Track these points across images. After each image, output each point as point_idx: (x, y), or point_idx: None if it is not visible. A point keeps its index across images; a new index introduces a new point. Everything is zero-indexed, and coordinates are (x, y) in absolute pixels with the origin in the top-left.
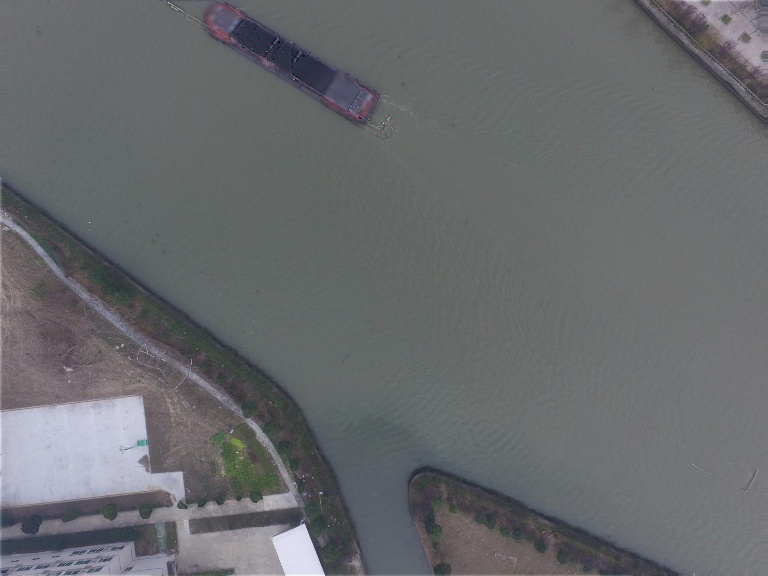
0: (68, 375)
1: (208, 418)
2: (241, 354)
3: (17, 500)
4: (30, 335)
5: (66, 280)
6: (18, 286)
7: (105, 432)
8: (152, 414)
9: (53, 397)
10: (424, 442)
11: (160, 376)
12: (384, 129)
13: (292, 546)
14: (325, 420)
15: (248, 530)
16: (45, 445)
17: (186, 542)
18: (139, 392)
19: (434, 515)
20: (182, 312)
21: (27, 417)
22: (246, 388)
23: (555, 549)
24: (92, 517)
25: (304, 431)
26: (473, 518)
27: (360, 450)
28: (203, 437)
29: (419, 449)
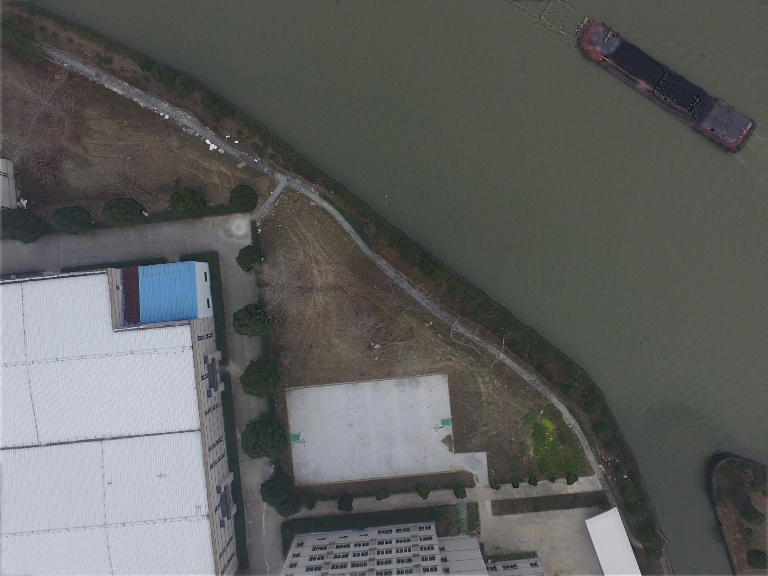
0: (375, 352)
1: (519, 398)
2: (540, 335)
3: (317, 478)
4: (343, 310)
5: (372, 256)
6: (330, 261)
7: (408, 410)
8: (457, 393)
9: (358, 374)
10: (725, 427)
11: (470, 355)
12: (692, 111)
13: (606, 529)
14: (626, 403)
15: (552, 513)
16: (347, 422)
17: (488, 523)
18: (444, 371)
19: (750, 501)
20: (484, 291)
21: (329, 394)
22: (552, 369)
23: None
24: (393, 496)
25: (610, 413)
26: None
27: (660, 434)
28: (514, 417)
29: (719, 434)
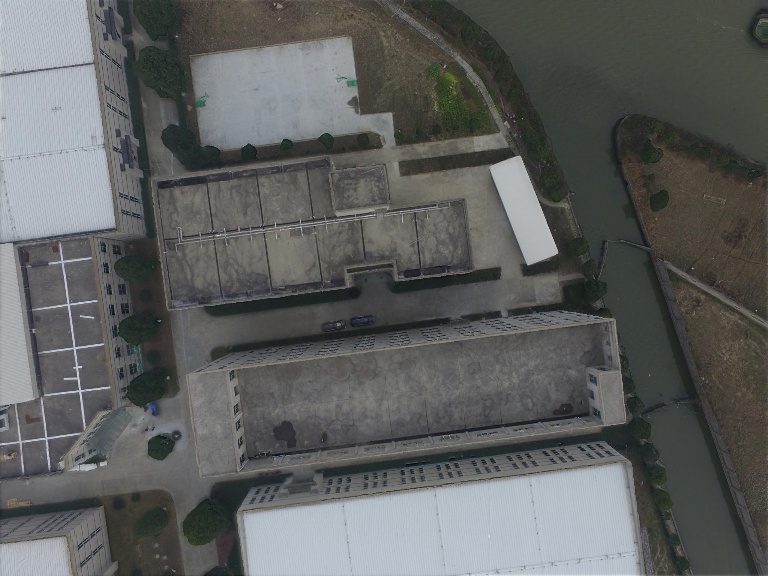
0: (278, 13)
1: (422, 51)
2: None
3: (224, 144)
4: None
5: None
6: None
7: (313, 73)
8: (361, 54)
9: (261, 37)
10: (629, 90)
11: (372, 11)
12: None
13: (510, 175)
14: (531, 67)
15: (459, 171)
16: (252, 87)
17: (396, 184)
18: (348, 32)
19: (651, 144)
20: None
21: (234, 59)
22: (455, 29)
23: (764, 189)
24: None
25: (514, 71)
26: (683, 158)
27: (565, 98)
28: (417, 70)
29: (624, 97)
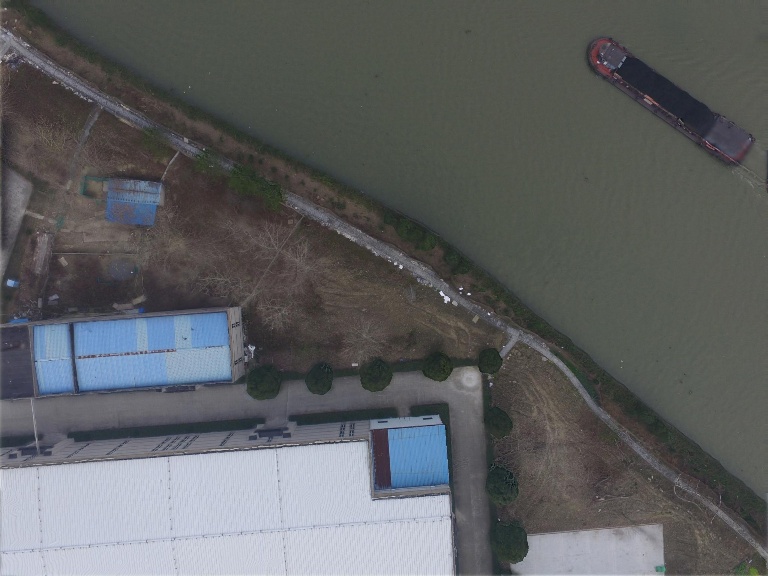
0: (598, 504)
1: (732, 549)
2: None
3: None
4: (574, 467)
5: (597, 411)
6: (563, 418)
7: (625, 558)
8: (671, 542)
9: (580, 524)
10: None
11: (688, 508)
12: None
13: None
14: None
15: None
16: (567, 569)
17: None
18: (660, 521)
19: None
20: None
21: (551, 542)
22: (757, 519)
23: None
24: None
25: None
26: None
27: None
28: (726, 567)
29: None
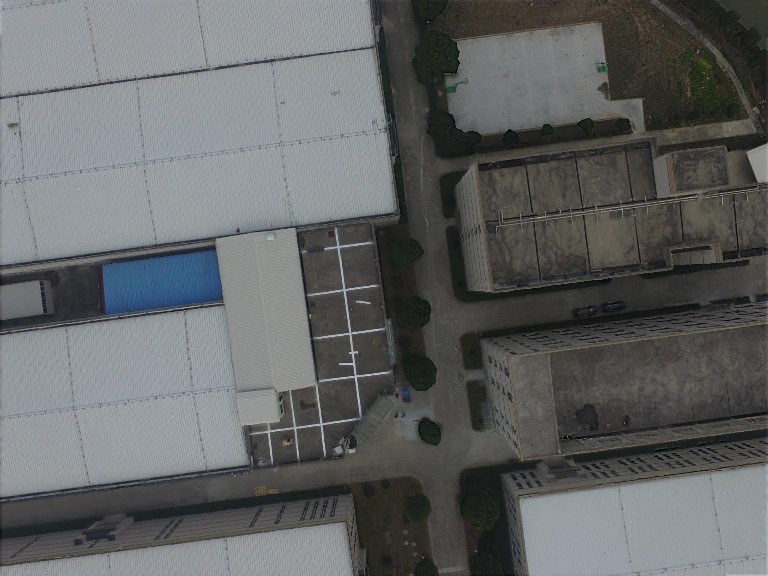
0: None
1: (676, 37)
2: None
3: (474, 130)
4: None
5: None
6: None
7: (564, 59)
8: (611, 40)
9: (513, 23)
10: None
11: None
12: None
13: (767, 160)
14: None
15: None
16: (503, 73)
17: None
18: (598, 18)
19: None
20: None
21: (484, 45)
22: (703, 15)
23: None
24: (550, 146)
25: None
26: None
27: None
28: (672, 56)
29: None
